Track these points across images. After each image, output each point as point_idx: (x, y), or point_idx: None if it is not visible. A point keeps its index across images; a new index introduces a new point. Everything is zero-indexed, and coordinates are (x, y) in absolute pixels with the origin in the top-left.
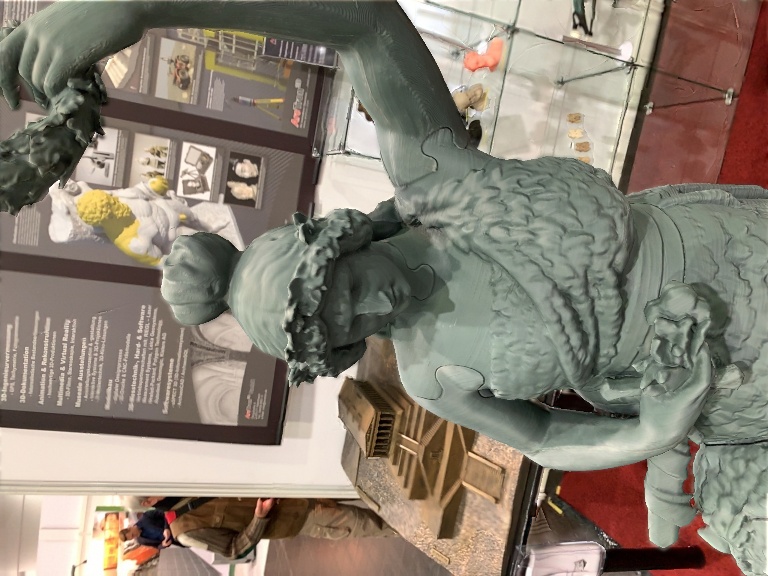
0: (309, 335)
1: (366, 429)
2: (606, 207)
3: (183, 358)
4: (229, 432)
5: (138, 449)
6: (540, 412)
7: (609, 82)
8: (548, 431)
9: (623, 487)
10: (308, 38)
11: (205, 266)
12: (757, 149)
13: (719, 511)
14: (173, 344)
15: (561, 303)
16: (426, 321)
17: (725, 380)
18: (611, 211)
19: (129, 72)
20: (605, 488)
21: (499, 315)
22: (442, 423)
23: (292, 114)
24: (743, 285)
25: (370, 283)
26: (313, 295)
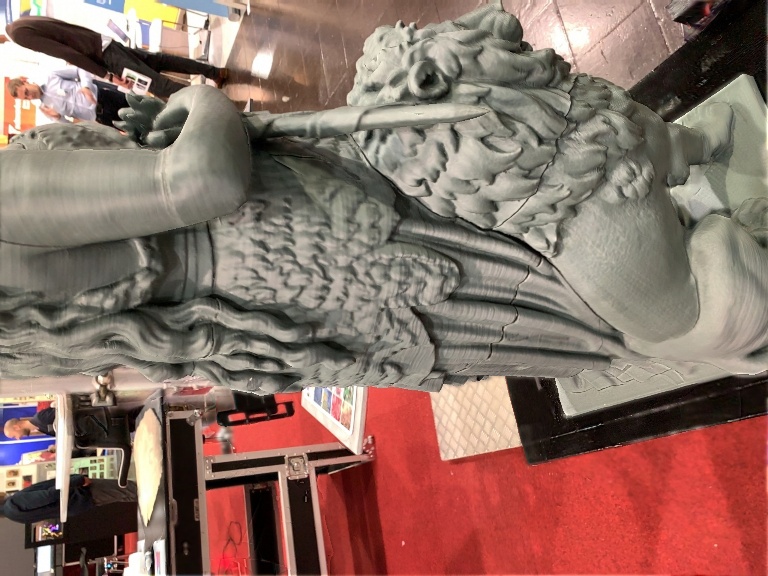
0: None
1: None
2: None
3: None
4: None
5: None
6: None
7: None
8: None
9: None
10: None
11: None
12: None
13: (383, 94)
14: None
15: None
16: None
17: None
18: None
19: None
20: None
21: None
22: None
23: None
24: None
25: None
26: None
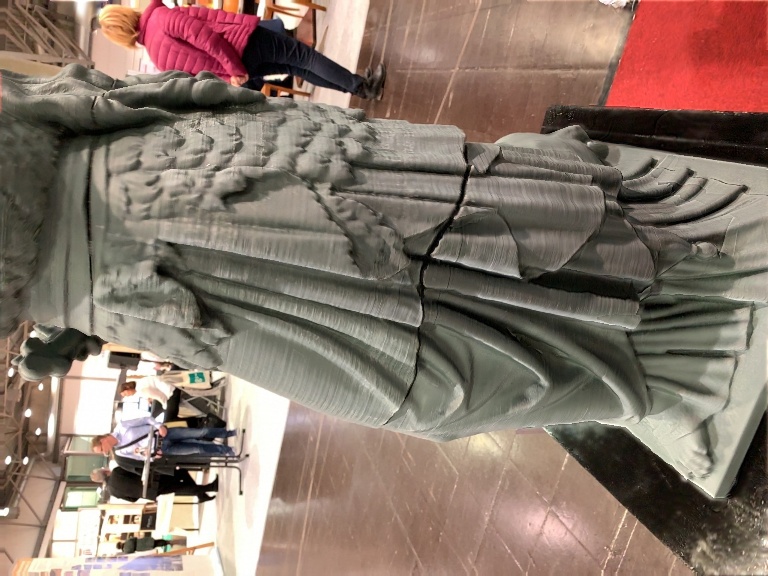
0: None
1: None
2: None
3: None
4: None
5: None
6: None
7: None
8: None
9: None
10: None
11: None
12: None
13: None
14: None
15: None
16: None
17: None
18: None
19: None
20: None
21: None
22: None
23: None
24: None
25: None
26: None
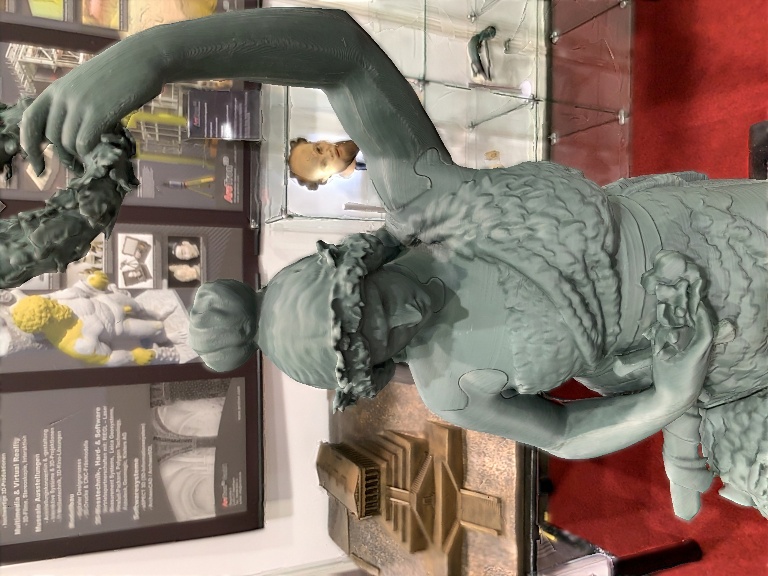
0: (355, 352)
1: (353, 489)
2: (588, 196)
3: (148, 455)
4: (208, 525)
5: (111, 565)
6: (556, 406)
7: (513, 121)
8: (568, 422)
9: (608, 497)
10: (304, 79)
11: (235, 308)
12: (656, 159)
13: (735, 467)
14: (135, 442)
15: (569, 288)
16: (442, 333)
17: (721, 335)
18: (593, 199)
19: (53, 173)
20: (591, 503)
21: (513, 311)
22: (429, 466)
23: (224, 191)
24: (713, 249)
25: (396, 297)
26: (354, 312)
